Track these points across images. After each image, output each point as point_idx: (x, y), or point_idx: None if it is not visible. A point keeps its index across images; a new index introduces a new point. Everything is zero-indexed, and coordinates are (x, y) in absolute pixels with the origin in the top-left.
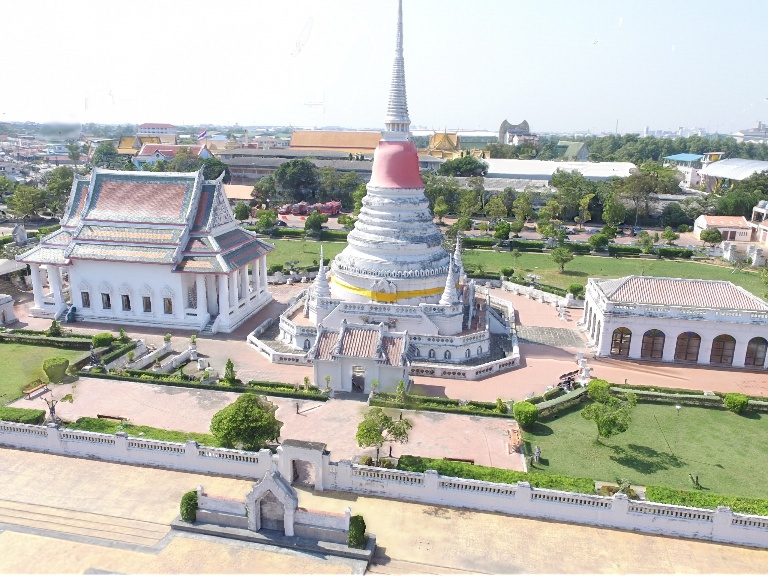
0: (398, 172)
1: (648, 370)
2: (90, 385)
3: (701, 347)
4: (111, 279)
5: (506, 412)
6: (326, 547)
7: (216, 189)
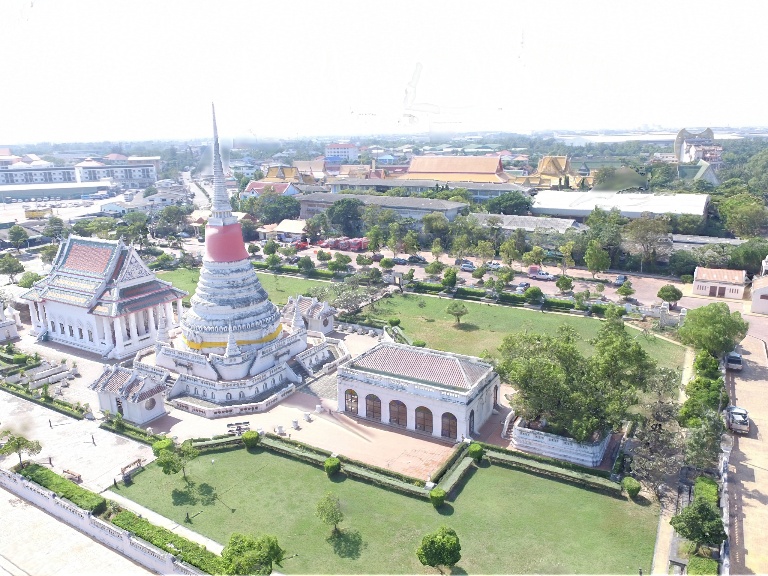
0: (215, 249)
1: (354, 429)
2: None
3: (407, 415)
4: (64, 314)
5: None
6: None
7: (127, 253)
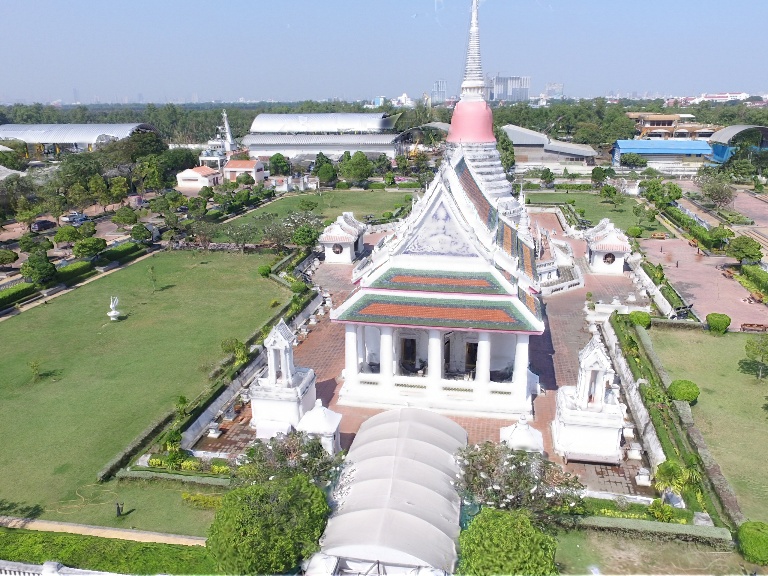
0: None
1: None
2: None
3: None
4: None
5: None
6: None
7: None
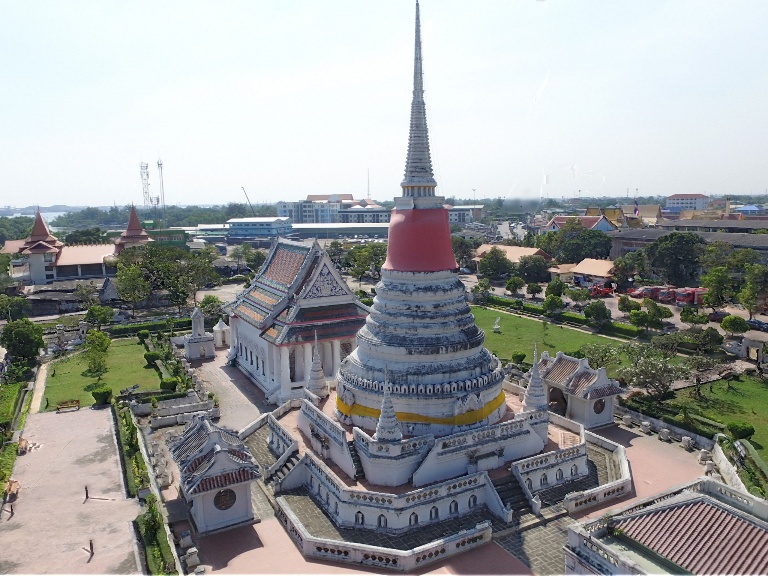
0: (397, 249)
1: None
2: (96, 415)
3: None
4: None
5: None
6: None
7: (318, 260)
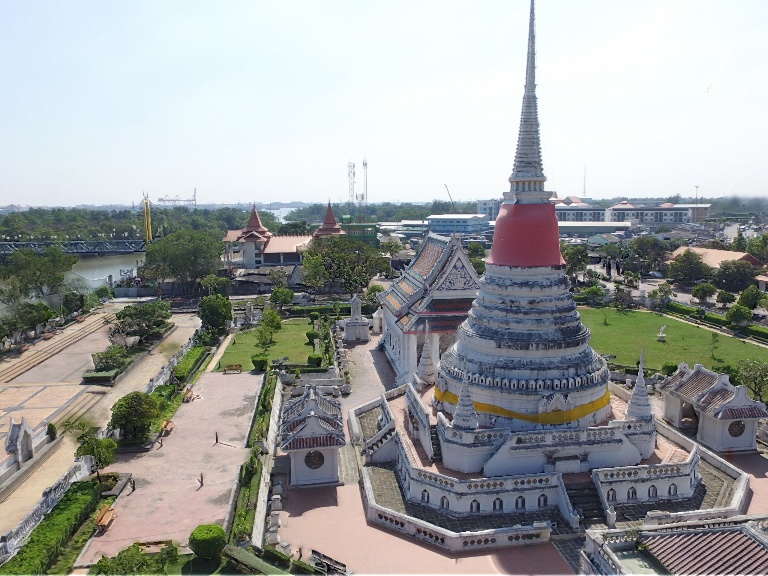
0: (498, 243)
1: None
2: (251, 379)
3: None
4: None
5: None
6: None
7: None
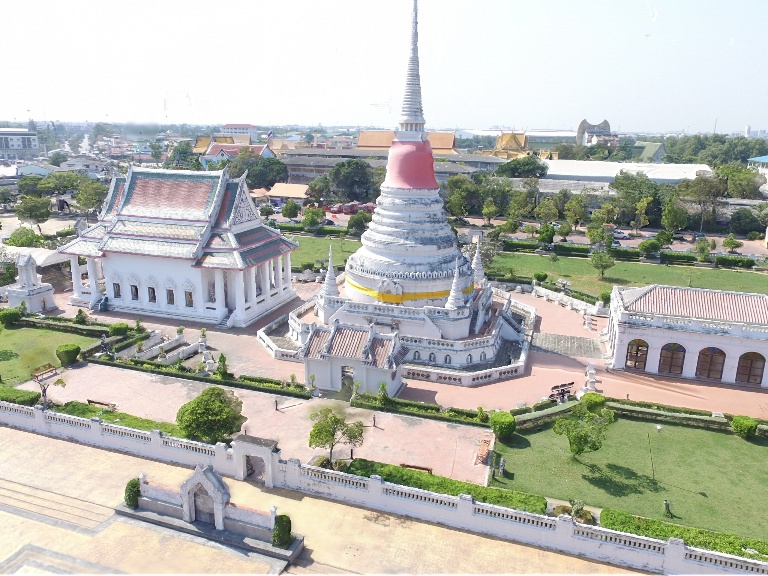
0: (410, 172)
1: (663, 386)
2: (95, 371)
3: (726, 364)
4: (139, 272)
5: (486, 421)
6: (250, 544)
7: (239, 187)
